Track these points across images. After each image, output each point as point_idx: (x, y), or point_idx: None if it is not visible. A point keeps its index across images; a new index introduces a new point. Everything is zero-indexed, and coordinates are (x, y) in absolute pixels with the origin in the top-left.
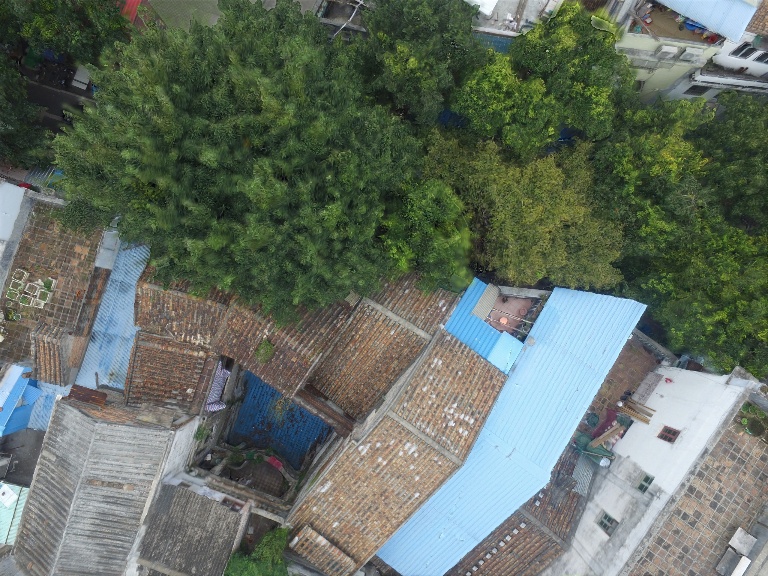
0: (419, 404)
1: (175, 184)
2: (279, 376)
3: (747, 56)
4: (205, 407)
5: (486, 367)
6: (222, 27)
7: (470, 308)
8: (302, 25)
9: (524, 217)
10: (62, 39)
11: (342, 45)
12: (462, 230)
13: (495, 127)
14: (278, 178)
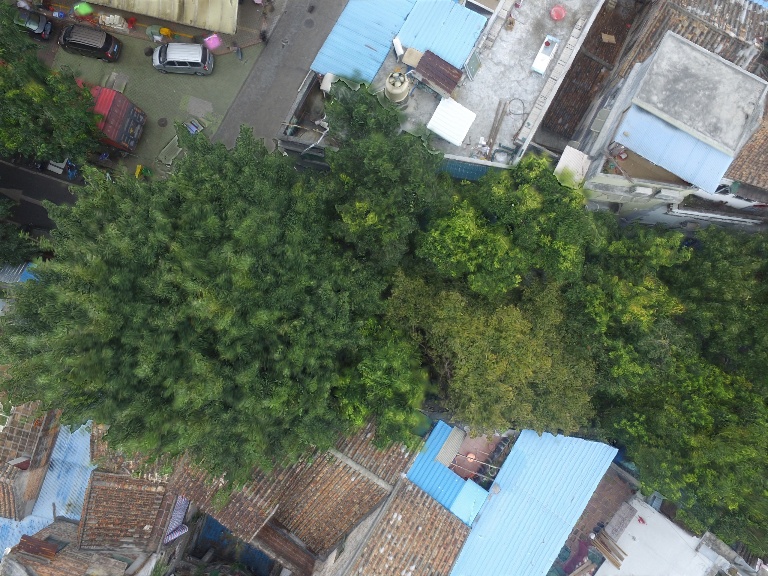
0: (375, 568)
1: (116, 370)
2: (236, 521)
3: (726, 193)
4: (164, 539)
5: (448, 519)
6: (176, 179)
7: (434, 454)
8: (262, 168)
9: (487, 373)
10: (28, 149)
11: (302, 192)
12: (429, 365)
13: (461, 271)
14: (221, 367)
